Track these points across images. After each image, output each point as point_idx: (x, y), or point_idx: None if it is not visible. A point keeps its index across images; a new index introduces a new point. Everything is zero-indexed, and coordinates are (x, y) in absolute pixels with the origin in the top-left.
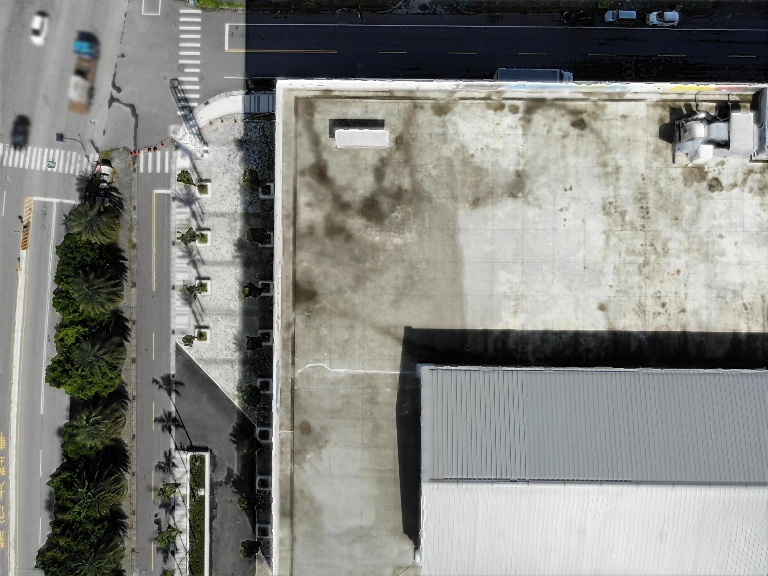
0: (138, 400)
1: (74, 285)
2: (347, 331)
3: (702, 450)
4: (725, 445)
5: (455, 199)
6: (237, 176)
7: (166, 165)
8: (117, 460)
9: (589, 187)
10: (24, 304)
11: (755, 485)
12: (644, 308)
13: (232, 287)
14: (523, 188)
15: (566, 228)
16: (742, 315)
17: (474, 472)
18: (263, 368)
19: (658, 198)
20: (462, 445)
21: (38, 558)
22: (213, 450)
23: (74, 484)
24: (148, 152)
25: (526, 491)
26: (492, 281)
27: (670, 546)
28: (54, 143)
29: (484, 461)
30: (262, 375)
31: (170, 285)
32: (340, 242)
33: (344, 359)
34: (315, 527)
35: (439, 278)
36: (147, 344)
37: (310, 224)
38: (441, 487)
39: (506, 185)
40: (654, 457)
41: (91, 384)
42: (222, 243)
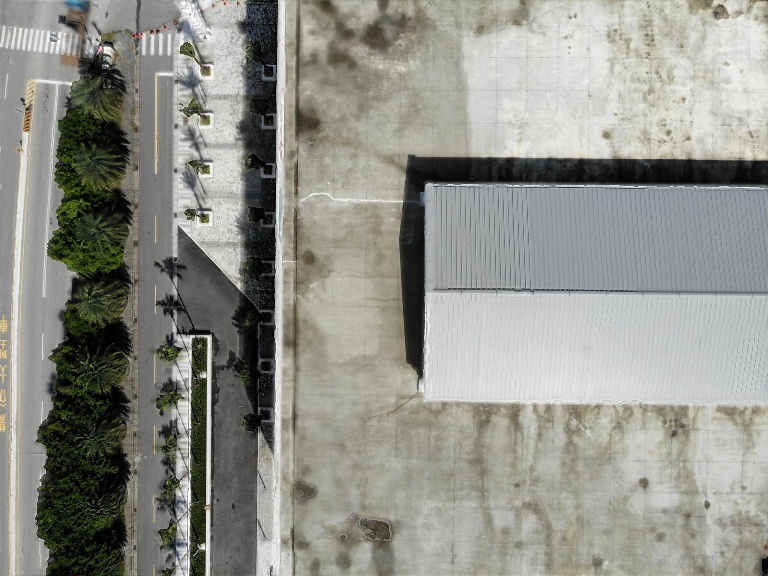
0: (140, 284)
1: (76, 156)
2: (350, 160)
3: (708, 262)
4: (731, 257)
5: (459, 27)
6: (240, 58)
7: (168, 48)
8: (119, 344)
9: (594, 15)
10: (26, 187)
11: (762, 295)
12: (649, 136)
13: (234, 170)
14: (527, 16)
15: (571, 56)
16: (748, 143)
17: (478, 282)
18: (265, 251)
19: (663, 26)
20: (466, 257)
21: (40, 432)
22: (215, 334)
23: (76, 358)
24: (150, 34)
25: (531, 301)
26: (496, 109)
27: (676, 362)
28: (56, 25)
29: (488, 272)
30: (264, 258)
31: (172, 168)
32: (343, 71)
33: (347, 188)
34: (318, 358)
35: (443, 106)
36: (149, 227)
37: (313, 53)
38: (445, 297)
39: (510, 13)
40: (660, 269)
41: (93, 259)
42: (224, 126)
